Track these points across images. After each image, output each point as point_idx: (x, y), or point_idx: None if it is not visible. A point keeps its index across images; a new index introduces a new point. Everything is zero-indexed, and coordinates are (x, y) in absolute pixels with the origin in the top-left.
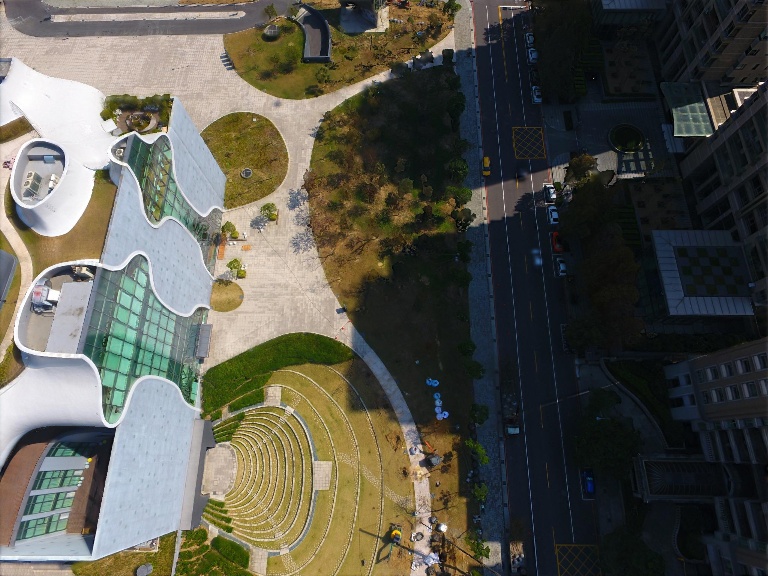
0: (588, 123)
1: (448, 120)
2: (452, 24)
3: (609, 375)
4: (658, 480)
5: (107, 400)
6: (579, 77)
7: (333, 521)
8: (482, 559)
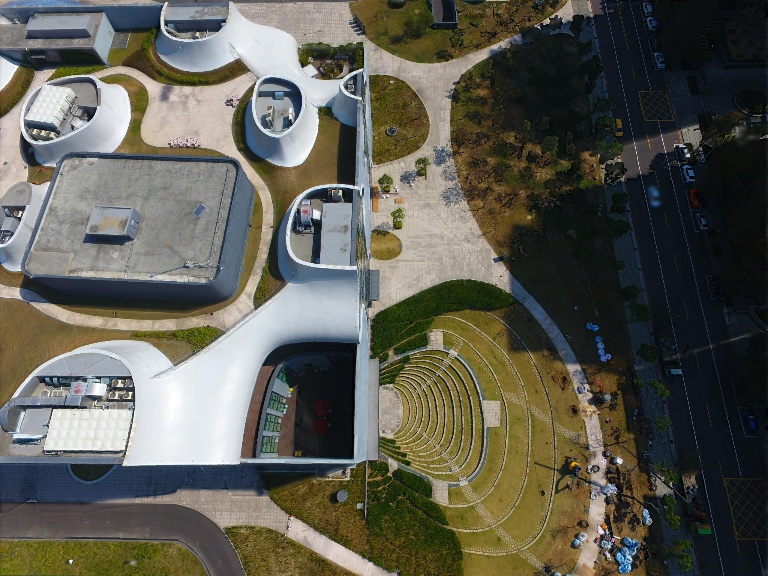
0: (712, 88)
1: (575, 84)
2: None
3: (760, 322)
4: None
5: None
6: (703, 43)
7: (508, 455)
8: (655, 491)
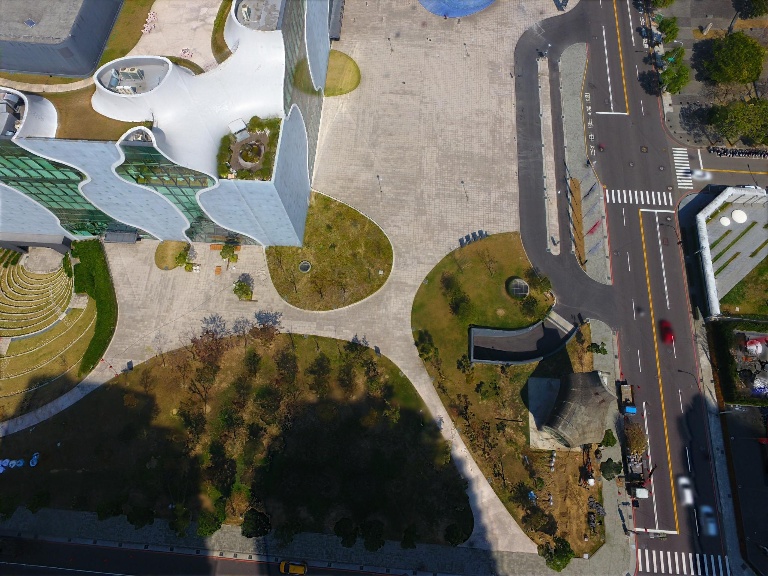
0: None
1: None
2: None
3: None
4: None
5: None
6: None
7: None
8: None
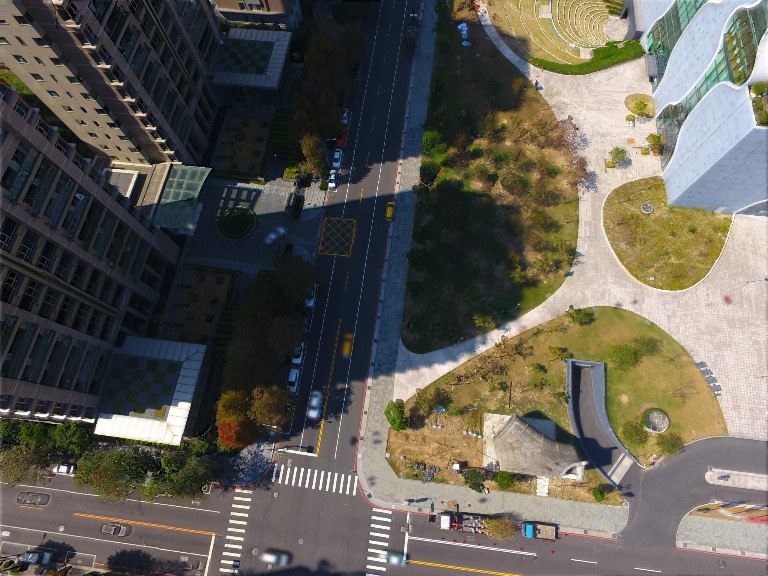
0: (267, 250)
1: (421, 272)
2: None
3: None
4: None
5: None
6: None
7: None
8: None
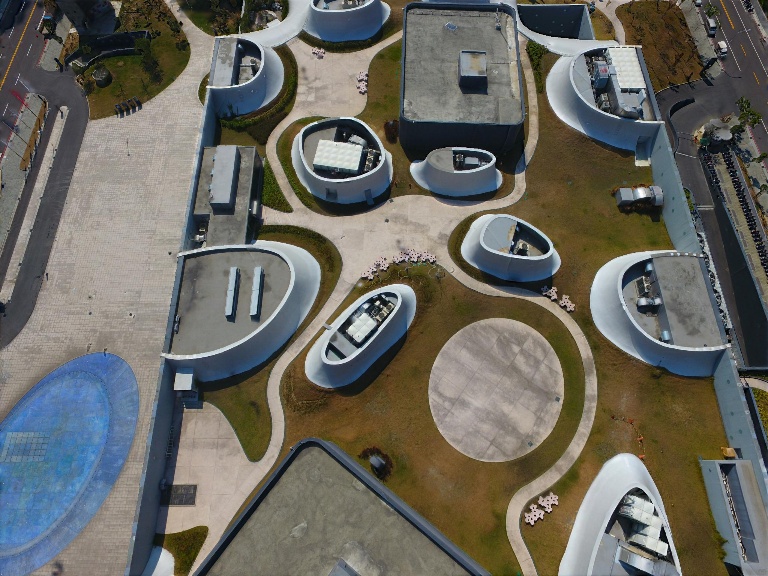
0: None
1: None
2: None
3: None
4: None
5: None
6: None
7: None
8: None
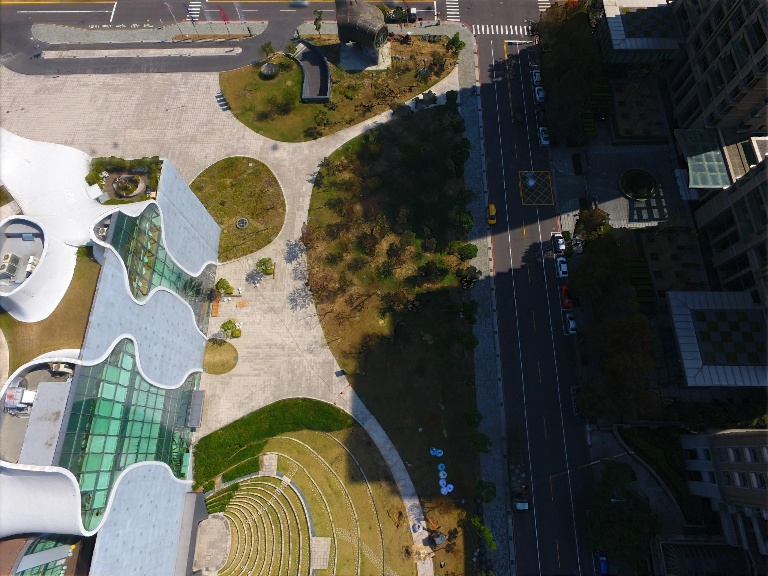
0: (598, 167)
1: (452, 164)
2: (456, 60)
3: (622, 443)
4: (677, 566)
5: (87, 505)
6: (588, 119)
7: None
8: None
